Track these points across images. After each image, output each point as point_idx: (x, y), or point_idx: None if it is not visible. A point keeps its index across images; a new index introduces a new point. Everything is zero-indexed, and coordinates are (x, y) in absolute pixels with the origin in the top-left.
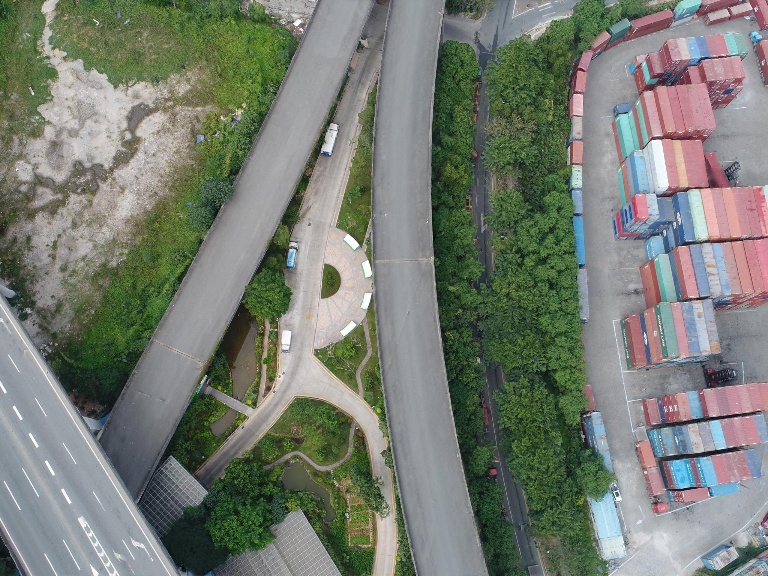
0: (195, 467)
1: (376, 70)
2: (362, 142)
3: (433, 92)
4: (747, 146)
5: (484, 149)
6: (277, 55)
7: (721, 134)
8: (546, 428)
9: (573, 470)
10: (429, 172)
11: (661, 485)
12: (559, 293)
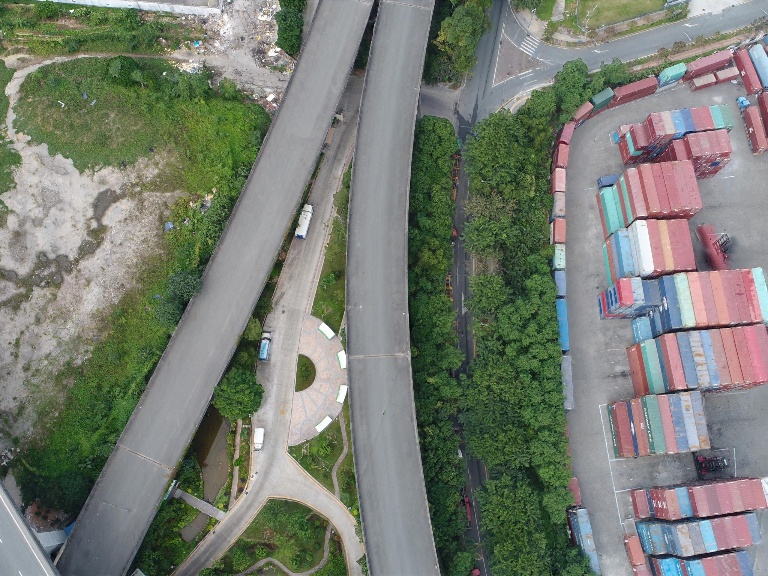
0: None
1: (352, 145)
2: (337, 226)
3: (409, 174)
4: (736, 217)
5: (464, 229)
6: (248, 135)
7: (709, 205)
8: (529, 529)
9: (559, 568)
10: (405, 260)
11: None
12: (542, 384)
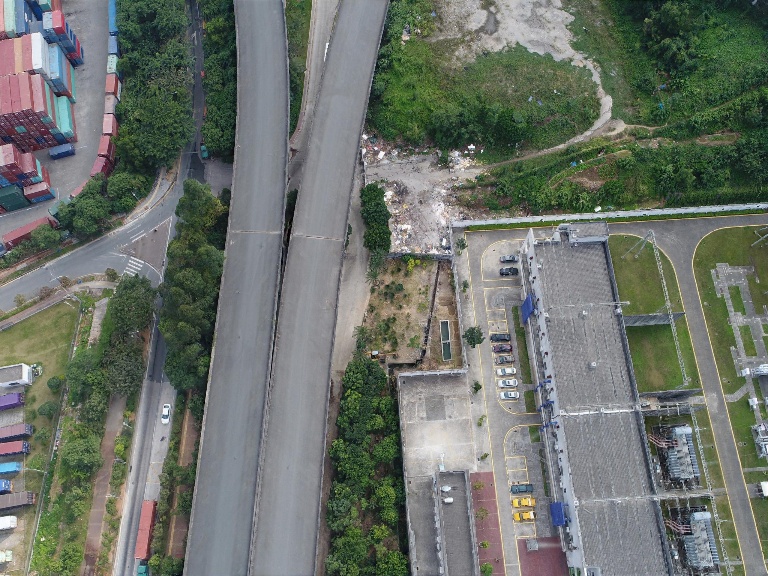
0: None
1: (301, 133)
2: None
3: None
4: None
5: None
6: None
7: None
8: None
9: None
10: None
11: None
12: None
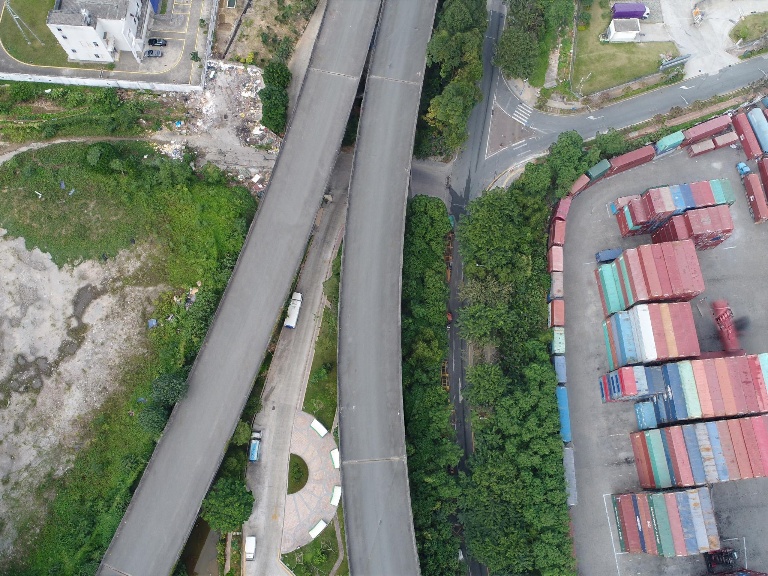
0: None
1: (341, 226)
2: (327, 318)
3: (401, 263)
4: (739, 290)
5: (459, 314)
6: (234, 222)
7: (711, 278)
8: None
9: None
10: (399, 356)
11: None
12: (544, 482)
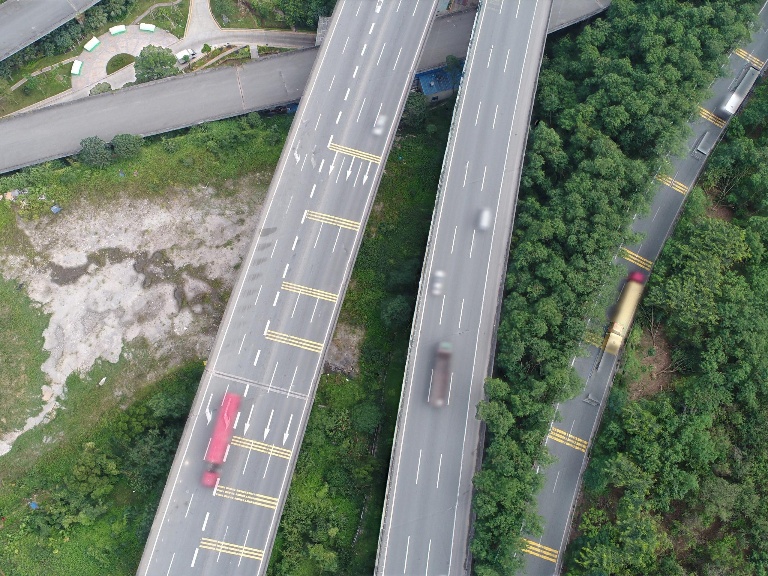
0: None
1: None
2: None
3: None
4: None
5: None
6: None
7: None
8: None
9: None
10: None
11: None
12: None
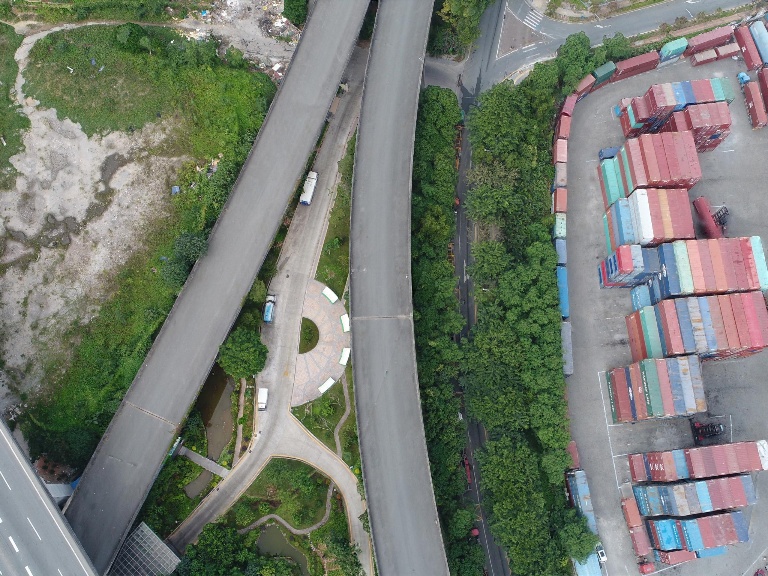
0: (168, 531)
1: (357, 115)
2: (341, 192)
3: (413, 141)
4: (735, 190)
5: (466, 197)
6: (255, 102)
7: (708, 178)
8: (528, 489)
9: (557, 529)
10: (409, 225)
11: (647, 544)
12: (542, 348)
